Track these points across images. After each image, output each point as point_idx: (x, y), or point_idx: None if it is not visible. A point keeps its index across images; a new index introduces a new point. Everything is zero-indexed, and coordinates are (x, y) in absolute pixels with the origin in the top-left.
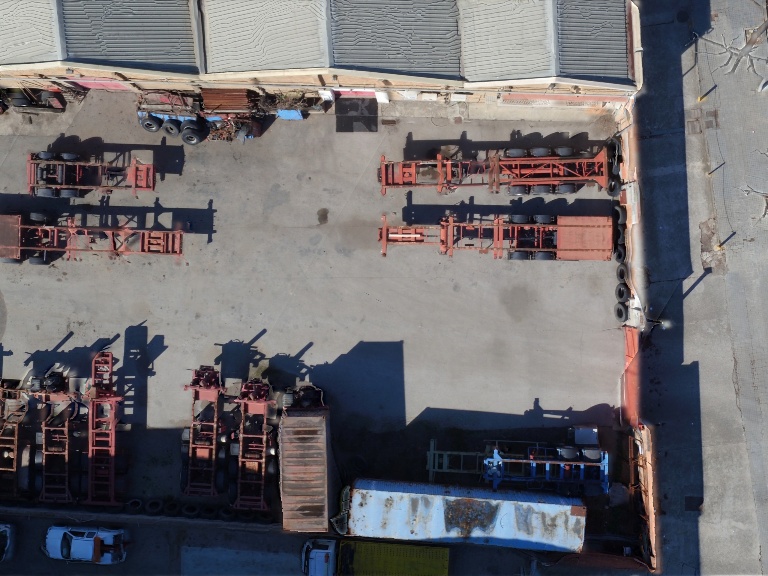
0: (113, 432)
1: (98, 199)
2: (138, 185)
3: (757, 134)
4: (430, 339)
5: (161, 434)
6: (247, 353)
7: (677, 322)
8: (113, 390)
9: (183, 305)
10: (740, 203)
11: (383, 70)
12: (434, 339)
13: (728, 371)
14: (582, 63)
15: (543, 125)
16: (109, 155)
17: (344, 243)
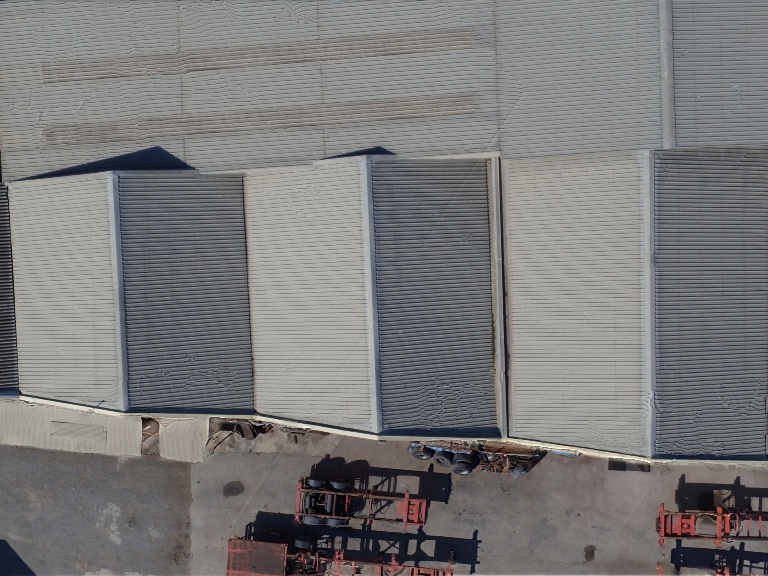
0: None
1: (360, 523)
2: (409, 519)
3: None
4: None
5: None
6: None
7: None
8: None
9: None
10: None
11: (699, 456)
12: None
13: None
14: None
15: None
16: (374, 479)
17: None
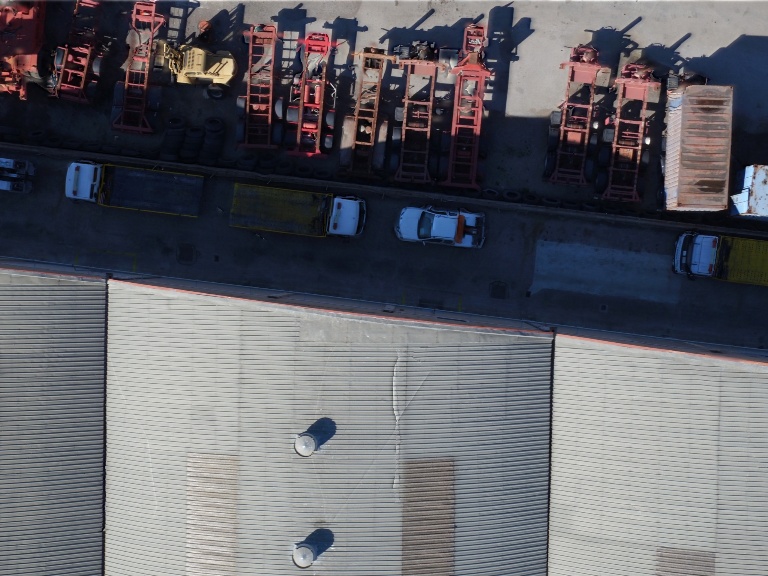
0: (480, 110)
1: None
2: None
3: None
4: None
5: (520, 123)
6: (619, 42)
7: None
8: (484, 65)
9: None
10: None
11: None
12: None
13: None
14: None
15: None
16: None
17: None
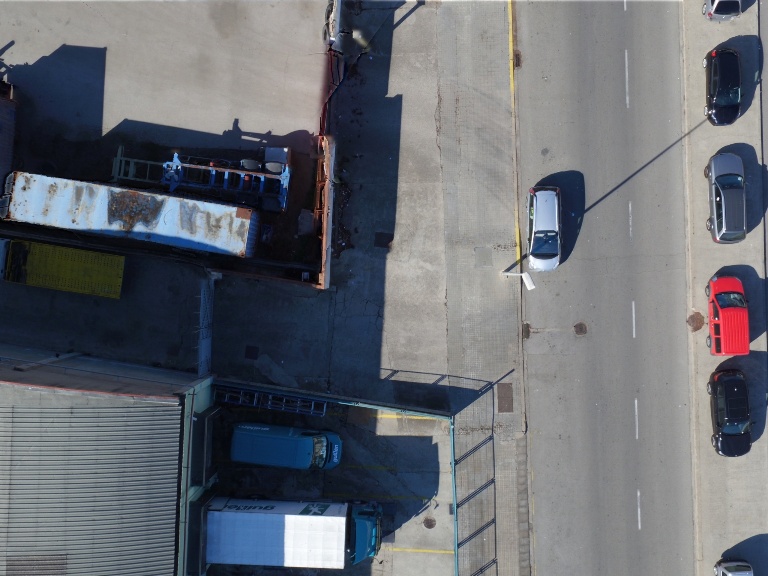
0: None
1: None
2: None
3: None
4: (134, 48)
5: None
6: None
7: (385, 52)
8: None
9: None
10: None
11: None
12: (138, 48)
13: (431, 107)
14: None
15: None
16: None
17: None
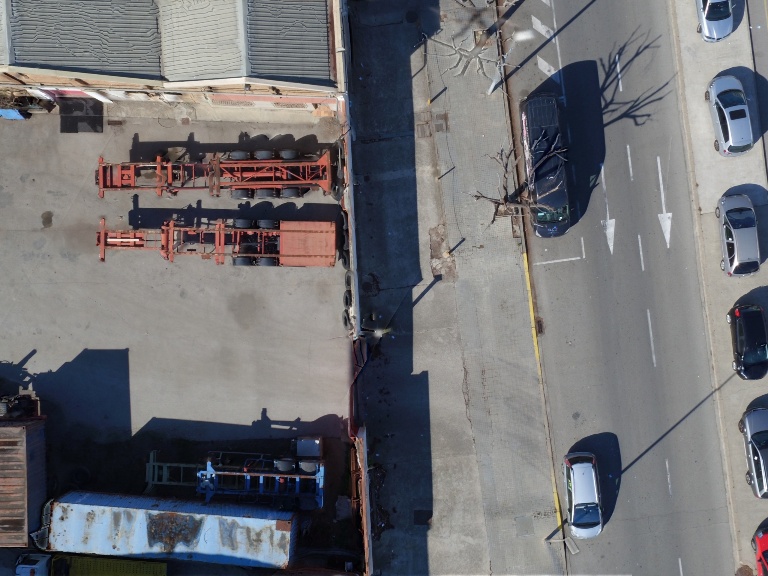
0: None
1: None
2: None
3: (487, 138)
4: (156, 347)
5: None
6: None
7: (406, 331)
8: None
9: None
10: (469, 209)
11: (71, 68)
12: (160, 347)
13: (458, 381)
14: (272, 63)
15: (264, 127)
16: None
17: (69, 247)
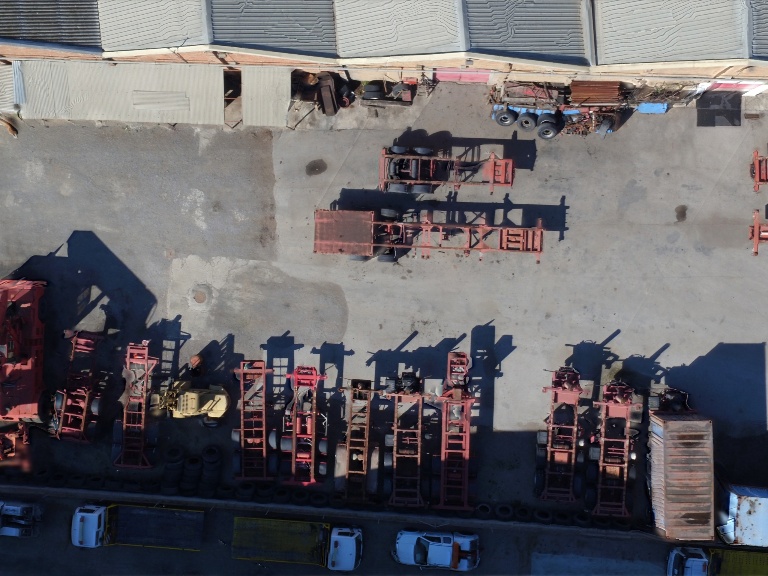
0: (468, 435)
1: (445, 195)
2: (496, 180)
3: None
4: None
5: (508, 437)
6: (600, 354)
7: None
8: (469, 391)
9: (533, 304)
10: None
11: None
12: None
13: None
14: None
15: None
16: (457, 149)
17: (703, 241)
